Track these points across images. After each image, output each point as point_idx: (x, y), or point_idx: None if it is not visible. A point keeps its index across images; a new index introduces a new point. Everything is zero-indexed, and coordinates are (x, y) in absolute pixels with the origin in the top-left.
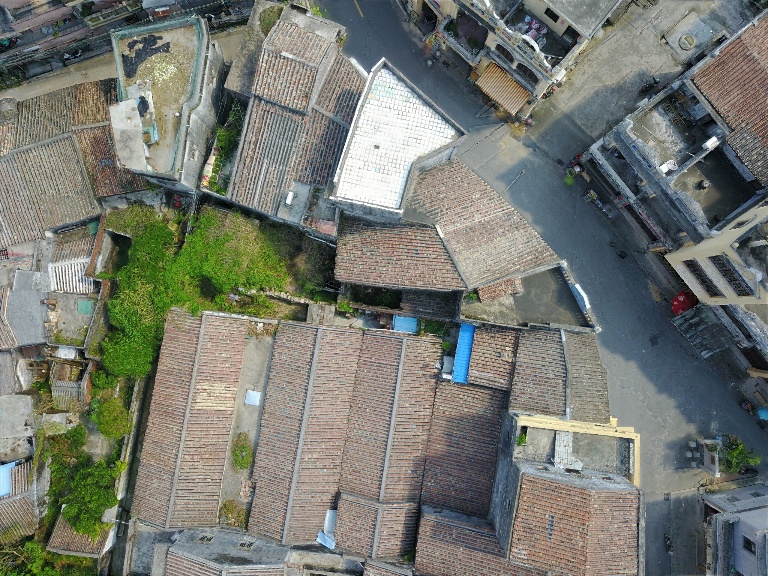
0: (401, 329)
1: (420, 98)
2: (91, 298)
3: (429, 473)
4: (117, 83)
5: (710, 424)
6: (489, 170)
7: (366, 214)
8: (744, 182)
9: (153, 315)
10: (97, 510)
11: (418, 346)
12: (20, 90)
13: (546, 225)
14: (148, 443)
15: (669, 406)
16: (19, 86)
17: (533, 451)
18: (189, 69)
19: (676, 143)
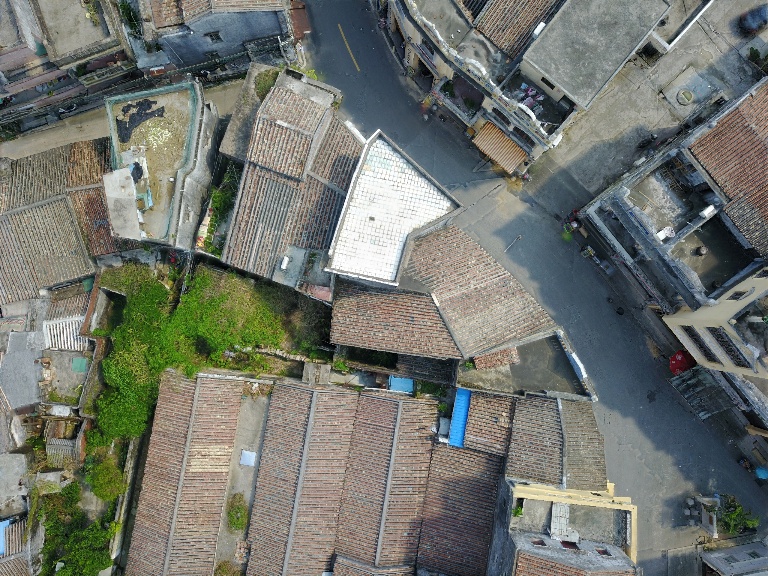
0: (397, 388)
1: (415, 169)
2: (86, 356)
3: (425, 536)
4: (111, 150)
5: (708, 481)
6: (486, 225)
7: (362, 279)
8: (742, 249)
9: (148, 375)
10: (91, 573)
11: (414, 408)
12: (15, 143)
13: (543, 280)
14: (143, 505)
15: (667, 463)
16: (14, 139)
17: (529, 521)
18: (184, 134)
19: (673, 209)
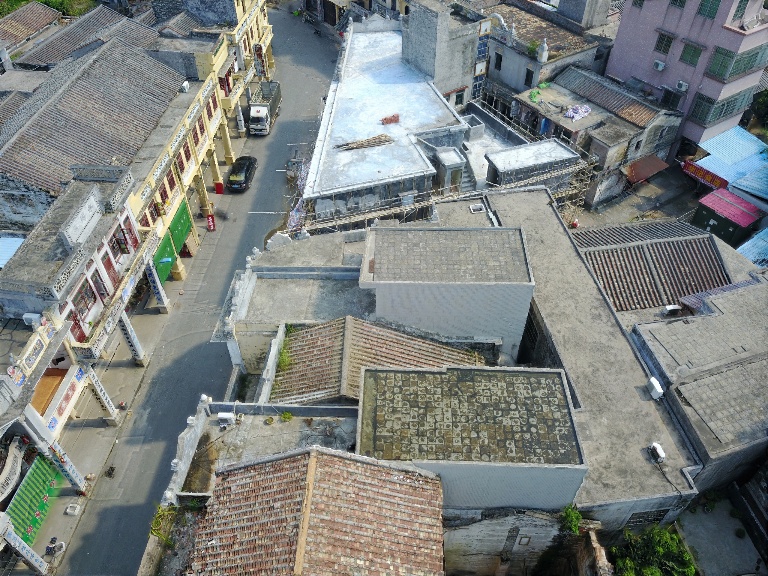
0: None
1: None
2: None
3: None
4: None
5: None
6: None
7: None
8: None
9: None
10: None
11: None
12: None
13: (276, 28)
14: None
15: None
16: None
17: None
18: None
19: None
